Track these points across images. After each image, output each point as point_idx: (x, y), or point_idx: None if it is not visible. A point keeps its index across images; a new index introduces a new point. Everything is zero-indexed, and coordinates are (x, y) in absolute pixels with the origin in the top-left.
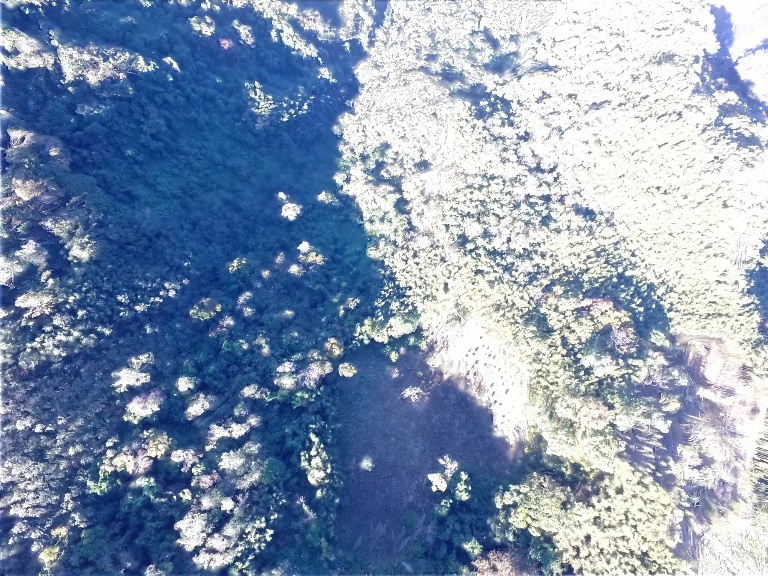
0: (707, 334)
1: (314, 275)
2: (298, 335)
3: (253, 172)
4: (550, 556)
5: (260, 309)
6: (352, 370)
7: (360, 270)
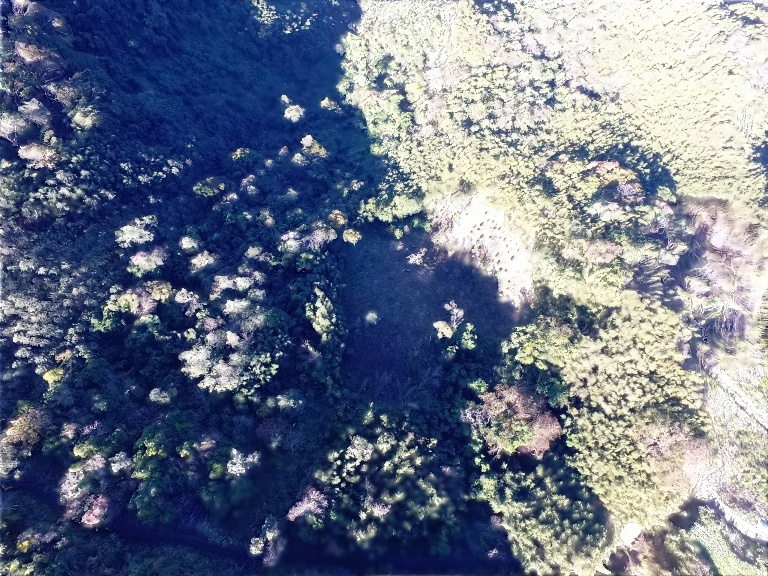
0: (713, 195)
1: (317, 167)
2: (302, 212)
3: (256, 82)
4: (557, 389)
5: (264, 192)
6: (357, 235)
7: (363, 167)
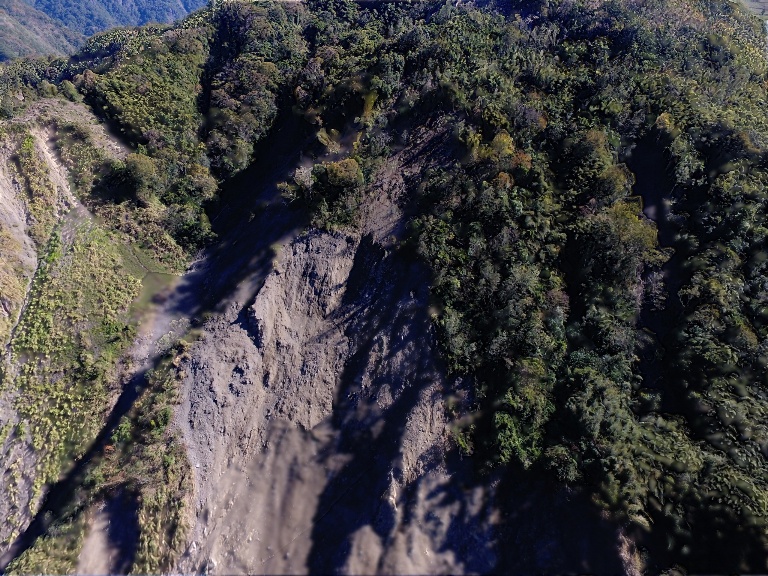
0: None
1: None
2: None
3: None
4: (40, 76)
5: None
6: None
7: None
